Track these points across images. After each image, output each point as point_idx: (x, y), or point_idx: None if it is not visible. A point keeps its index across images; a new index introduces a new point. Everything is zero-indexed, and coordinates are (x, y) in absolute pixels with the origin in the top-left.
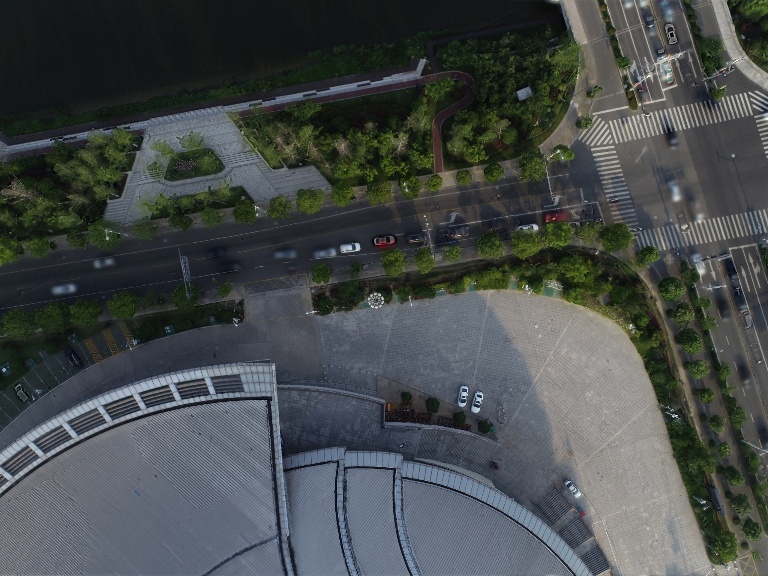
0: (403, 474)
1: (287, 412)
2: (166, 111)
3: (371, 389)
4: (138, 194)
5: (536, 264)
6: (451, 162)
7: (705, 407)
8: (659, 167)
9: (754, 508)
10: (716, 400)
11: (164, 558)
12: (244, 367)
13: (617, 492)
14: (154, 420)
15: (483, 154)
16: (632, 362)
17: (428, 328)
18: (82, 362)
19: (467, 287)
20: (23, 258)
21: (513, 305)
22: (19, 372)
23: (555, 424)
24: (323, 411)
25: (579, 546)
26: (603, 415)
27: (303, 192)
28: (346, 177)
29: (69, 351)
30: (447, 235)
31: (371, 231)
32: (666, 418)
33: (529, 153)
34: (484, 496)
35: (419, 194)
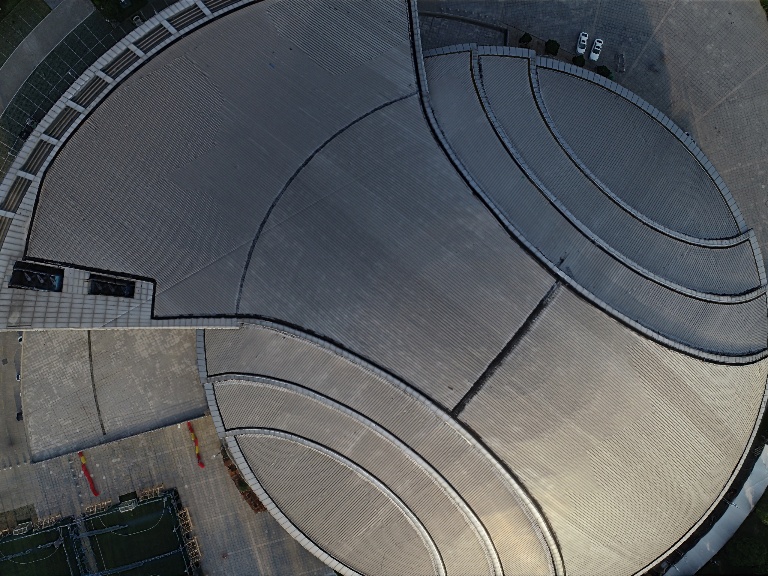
0: (537, 64)
1: None
2: None
3: None
4: None
5: None
6: None
7: None
8: None
9: None
10: None
11: (300, 120)
12: None
13: (733, 148)
14: None
15: None
16: (755, 16)
17: None
18: None
19: None
20: None
21: None
22: (137, 5)
23: (674, 76)
24: (445, 37)
25: None
26: (723, 69)
27: None
28: None
29: None
30: None
31: None
32: None
33: None
34: (618, 90)
35: None
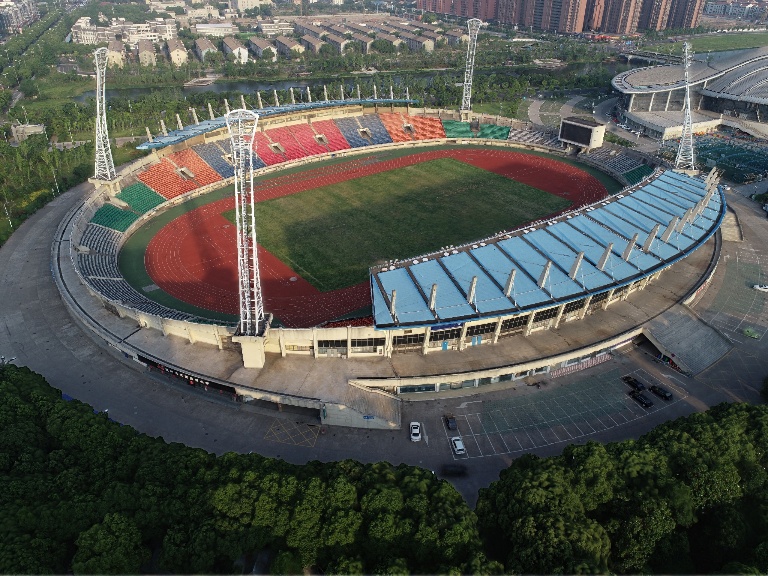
0: None
1: None
2: None
3: None
4: None
5: None
6: None
7: None
8: None
9: None
10: None
11: None
12: None
13: None
14: None
15: None
16: None
17: None
18: None
19: None
20: None
21: None
22: (600, 96)
23: None
24: None
25: None
26: None
27: None
28: None
29: (613, 93)
30: None
31: None
32: None
33: None
34: None
35: None
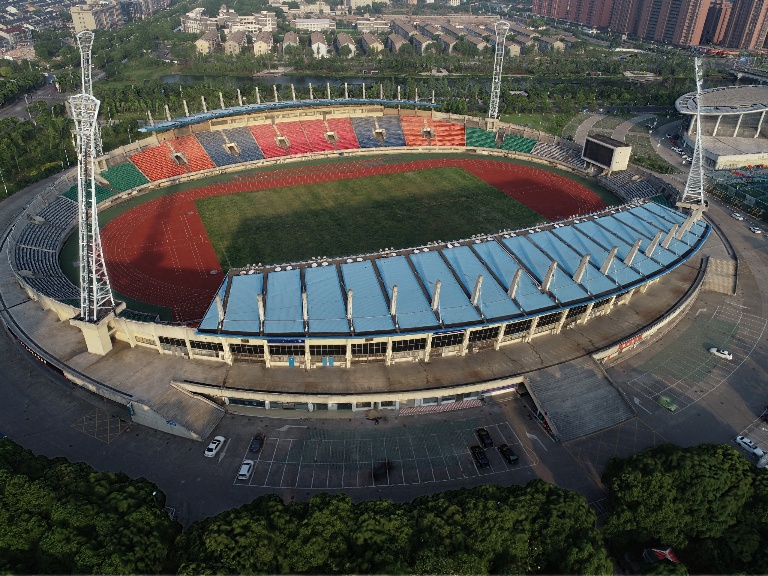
0: None
1: None
2: None
3: None
4: None
5: None
6: None
7: None
8: None
9: None
10: None
11: None
12: None
13: None
14: None
15: None
16: None
17: None
18: None
19: None
20: None
21: None
22: None
23: None
24: None
25: None
26: None
27: None
28: None
29: None
30: None
31: None
32: None
33: None
34: None
35: None
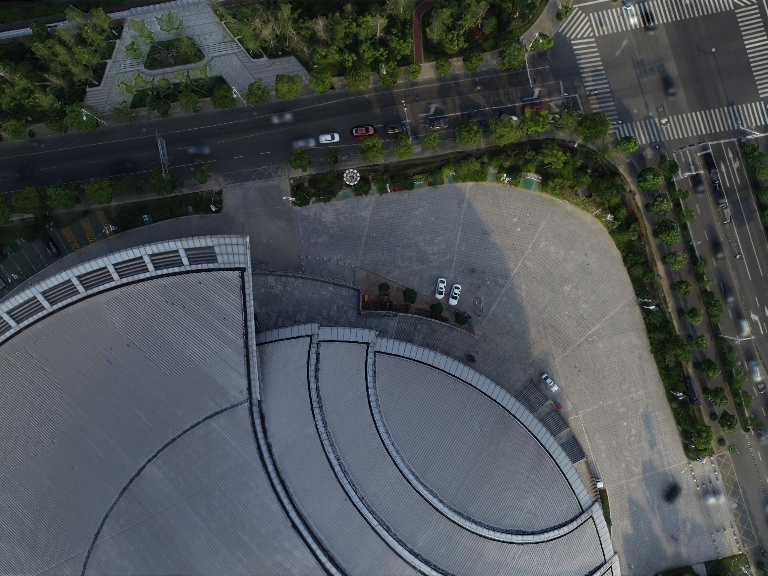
0: (376, 348)
1: (263, 297)
2: (147, 1)
3: (349, 281)
4: (117, 83)
5: (514, 152)
6: (431, 53)
7: (683, 302)
8: (639, 60)
9: (731, 404)
10: (694, 295)
11: (135, 424)
12: (218, 239)
13: (594, 387)
14: (127, 291)
15: (462, 40)
16: (610, 256)
17: (406, 220)
18: (60, 250)
19: (446, 179)
20: (2, 146)
21: (492, 198)
22: None
23: (533, 318)
24: (299, 297)
25: (555, 437)
26: (581, 309)
27: (281, 76)
28: (325, 62)
29: (47, 239)
30: (426, 126)
31: (350, 122)
32: (644, 312)
33: (508, 39)
34: (457, 372)
35: (399, 85)
